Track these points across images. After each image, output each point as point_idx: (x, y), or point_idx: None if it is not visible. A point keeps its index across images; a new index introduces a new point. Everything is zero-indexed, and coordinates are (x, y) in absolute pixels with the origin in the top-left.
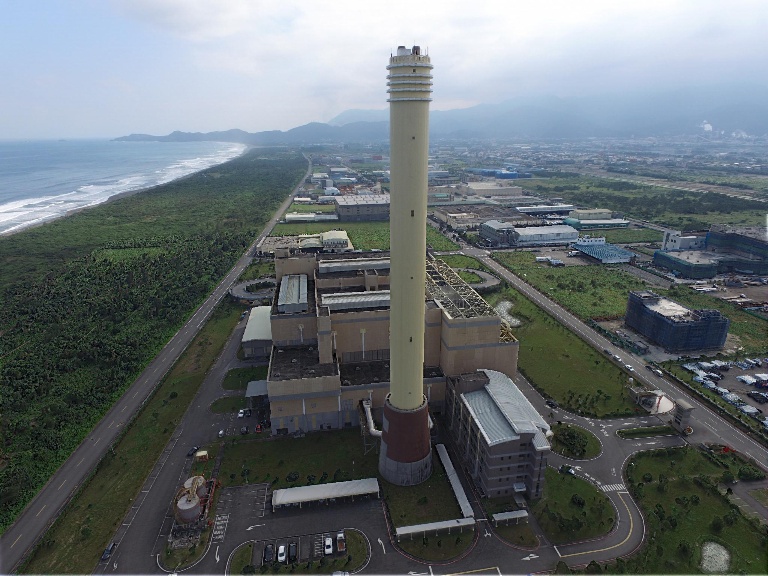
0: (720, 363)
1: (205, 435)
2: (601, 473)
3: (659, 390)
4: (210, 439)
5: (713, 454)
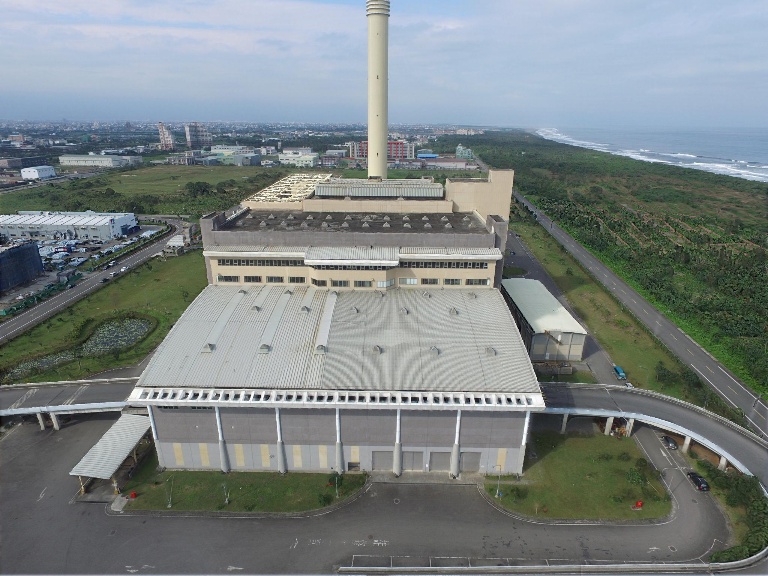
0: None
1: (513, 259)
2: None
3: (172, 238)
4: (507, 257)
5: None
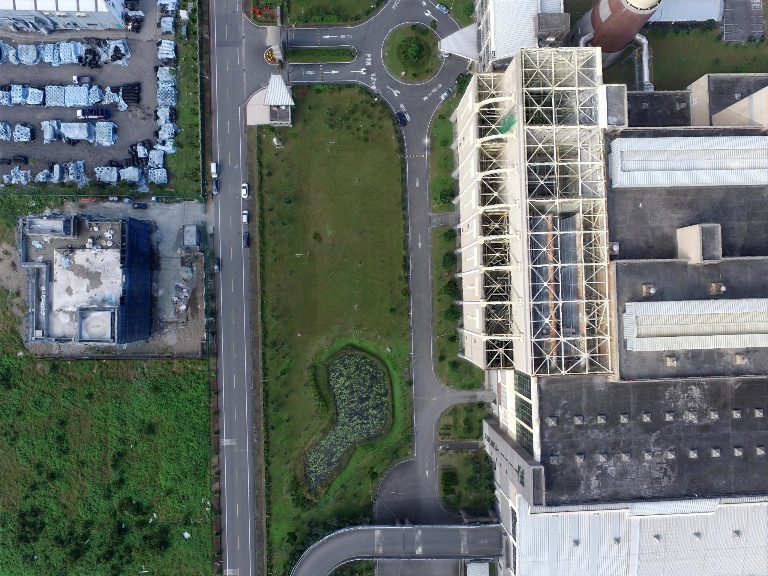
0: (109, 171)
1: None
2: (410, 3)
3: (269, 90)
4: None
5: (281, 5)
